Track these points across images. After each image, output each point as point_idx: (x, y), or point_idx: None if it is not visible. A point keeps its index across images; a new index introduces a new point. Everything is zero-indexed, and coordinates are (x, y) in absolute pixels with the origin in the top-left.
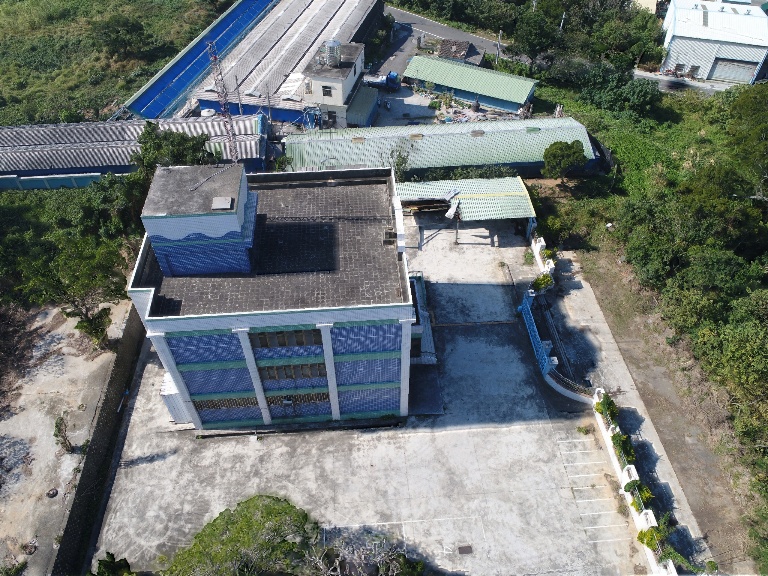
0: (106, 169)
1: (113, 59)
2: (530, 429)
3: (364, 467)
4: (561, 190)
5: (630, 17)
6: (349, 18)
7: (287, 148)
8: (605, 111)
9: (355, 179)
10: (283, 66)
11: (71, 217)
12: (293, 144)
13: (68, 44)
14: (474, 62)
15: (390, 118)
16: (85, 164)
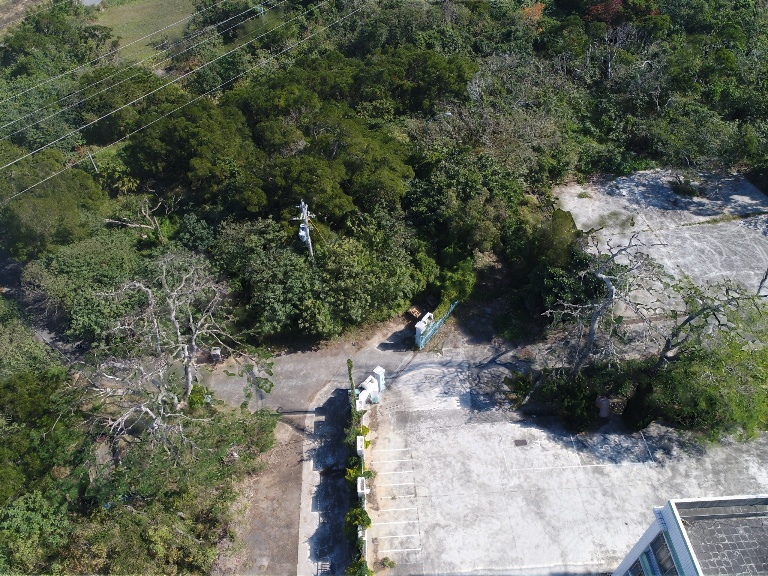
0: None
1: None
2: (450, 567)
3: (634, 522)
4: None
5: None
6: None
7: None
8: None
9: None
10: None
11: None
12: None
13: None
14: None
15: None
16: None
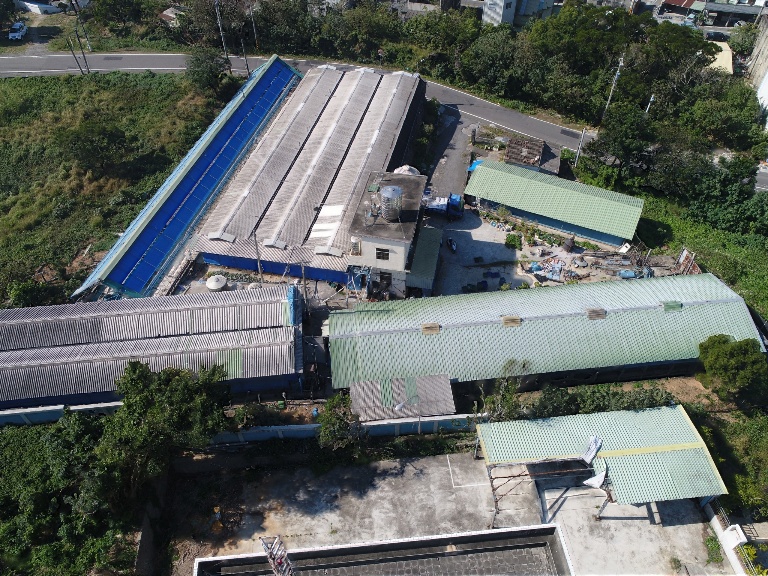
0: (72, 395)
1: (86, 176)
2: None
3: None
4: (722, 399)
5: (722, 91)
6: (388, 113)
7: (332, 346)
8: (724, 233)
9: (493, 543)
10: (312, 194)
11: (17, 494)
12: (340, 339)
13: (28, 153)
14: (552, 170)
15: (458, 265)
16: (40, 393)
